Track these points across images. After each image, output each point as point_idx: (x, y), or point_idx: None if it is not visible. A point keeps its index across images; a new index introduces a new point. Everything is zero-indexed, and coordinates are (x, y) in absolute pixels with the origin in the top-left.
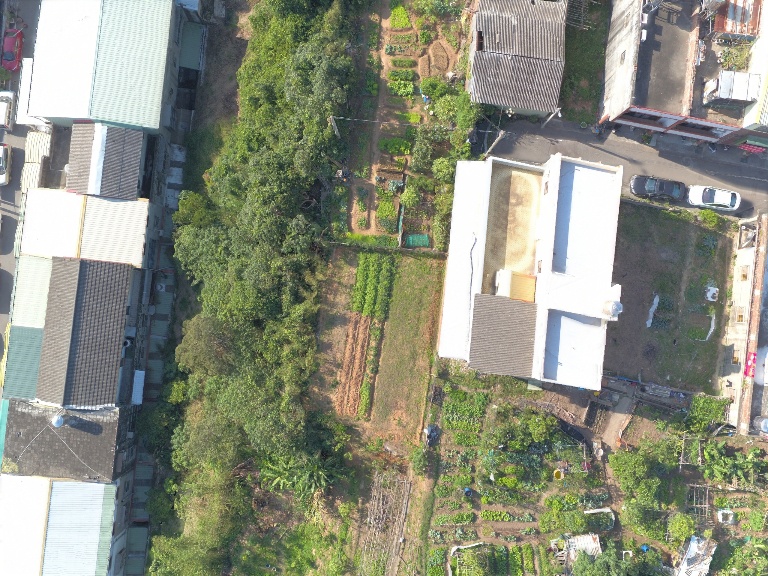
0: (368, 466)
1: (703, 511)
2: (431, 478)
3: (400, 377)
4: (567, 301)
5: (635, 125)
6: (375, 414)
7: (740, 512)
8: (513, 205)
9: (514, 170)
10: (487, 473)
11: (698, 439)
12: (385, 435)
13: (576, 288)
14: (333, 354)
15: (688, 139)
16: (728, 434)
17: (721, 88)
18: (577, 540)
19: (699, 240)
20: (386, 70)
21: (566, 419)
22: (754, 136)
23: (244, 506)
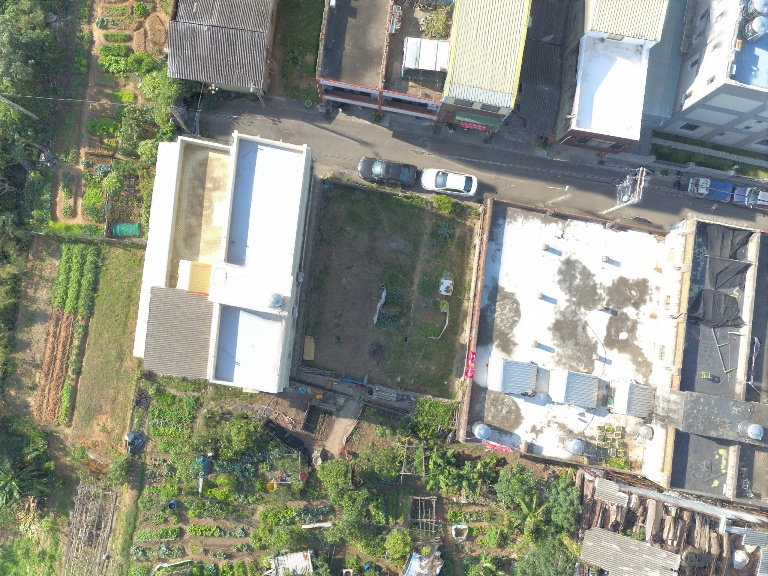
0: None
1: (429, 526)
2: (134, 489)
3: (105, 379)
4: (236, 294)
5: (346, 101)
6: (77, 419)
7: (477, 527)
8: (209, 190)
9: (211, 151)
10: (196, 484)
11: (421, 447)
12: (88, 442)
13: (253, 280)
14: (32, 354)
15: (425, 118)
16: None
17: (407, 57)
18: (287, 558)
19: (434, 228)
20: (98, 45)
21: (285, 425)
22: (462, 112)
23: None
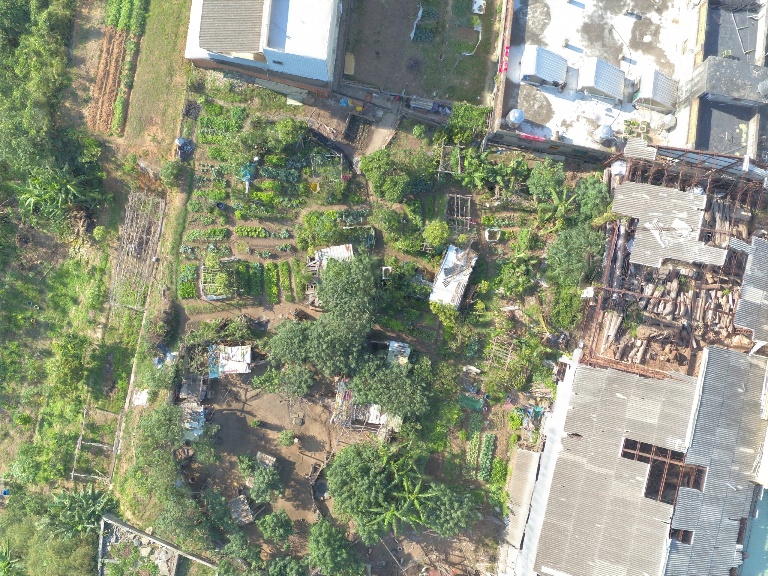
0: (129, 193)
1: (464, 223)
2: (183, 192)
3: (156, 92)
4: None
5: None
6: (129, 130)
7: (509, 231)
8: None
9: None
10: (242, 188)
11: (457, 146)
12: (139, 151)
13: None
14: (86, 68)
15: None
16: (497, 152)
17: None
18: (330, 249)
19: None
20: None
21: (327, 134)
22: None
23: (5, 240)
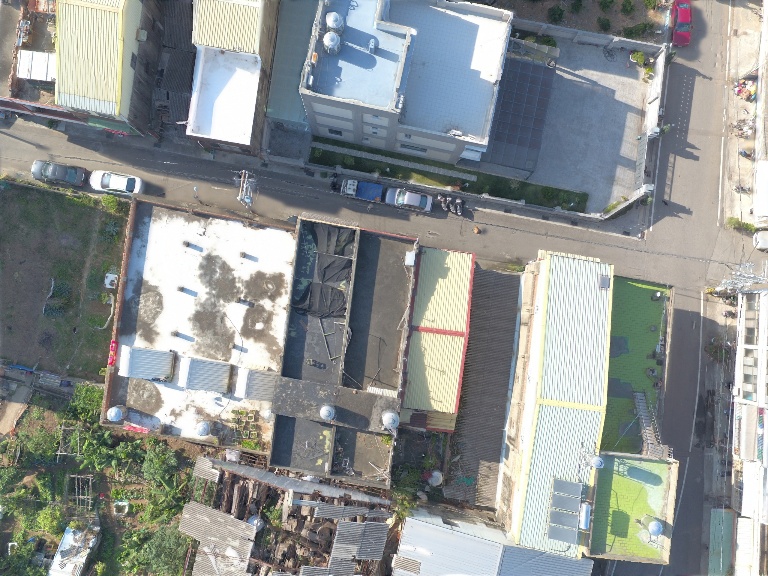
0: None
1: (85, 502)
2: None
3: None
4: None
5: (3, 108)
6: None
7: (137, 504)
8: None
9: None
10: None
11: (77, 429)
12: None
13: None
14: None
15: None
16: None
17: (20, 68)
18: None
19: (103, 226)
20: None
21: None
22: (93, 118)
23: None
